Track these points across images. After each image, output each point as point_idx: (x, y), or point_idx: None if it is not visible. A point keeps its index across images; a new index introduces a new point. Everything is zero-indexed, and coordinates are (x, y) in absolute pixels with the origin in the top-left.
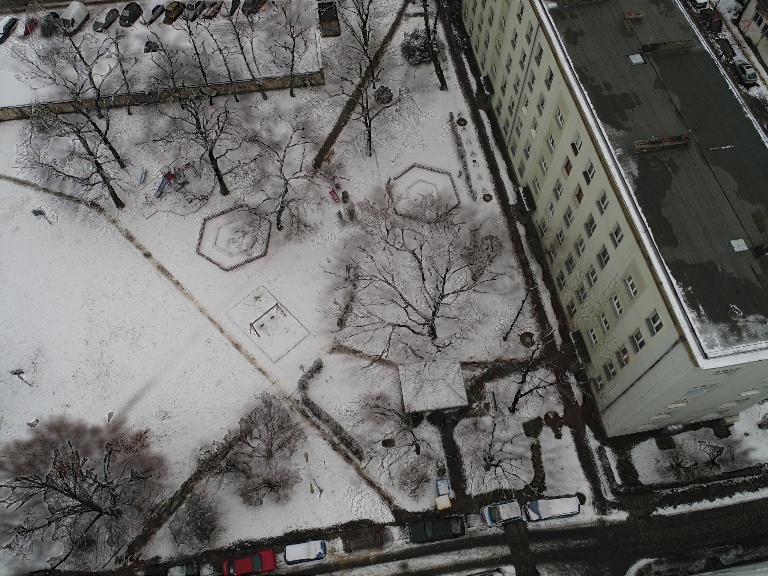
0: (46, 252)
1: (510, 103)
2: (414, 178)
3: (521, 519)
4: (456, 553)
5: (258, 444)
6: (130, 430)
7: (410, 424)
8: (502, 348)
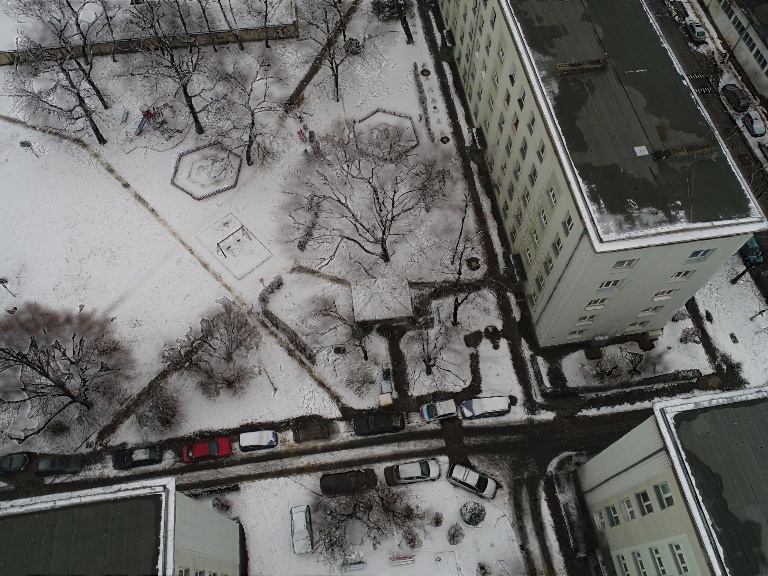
0: (32, 181)
1: (467, 51)
2: (377, 121)
3: (457, 417)
4: (396, 445)
5: (219, 347)
6: (104, 336)
7: (360, 333)
8: (449, 271)
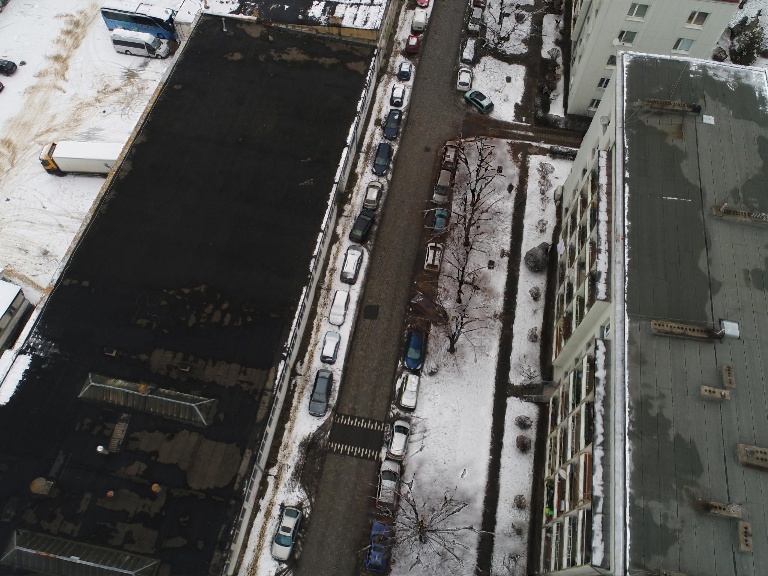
0: None
1: None
2: None
3: None
4: None
5: None
6: None
7: None
8: None
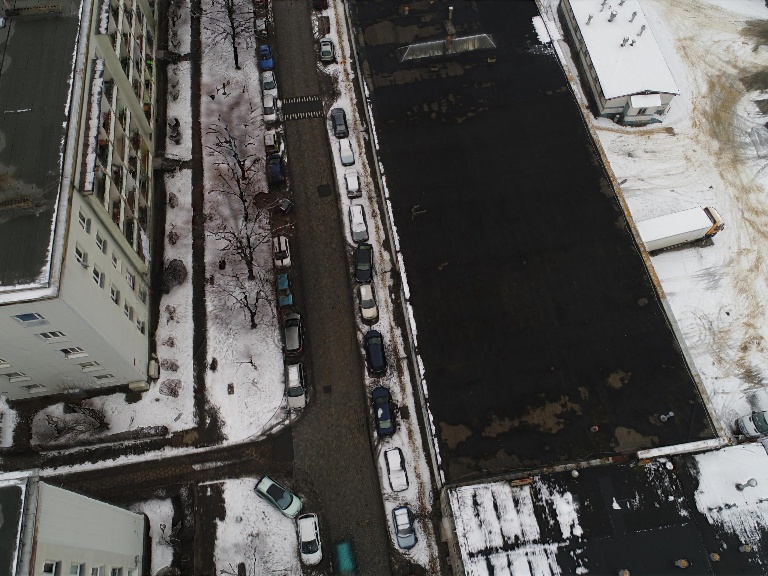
0: None
1: None
2: None
3: None
4: None
5: None
6: None
7: None
8: None
